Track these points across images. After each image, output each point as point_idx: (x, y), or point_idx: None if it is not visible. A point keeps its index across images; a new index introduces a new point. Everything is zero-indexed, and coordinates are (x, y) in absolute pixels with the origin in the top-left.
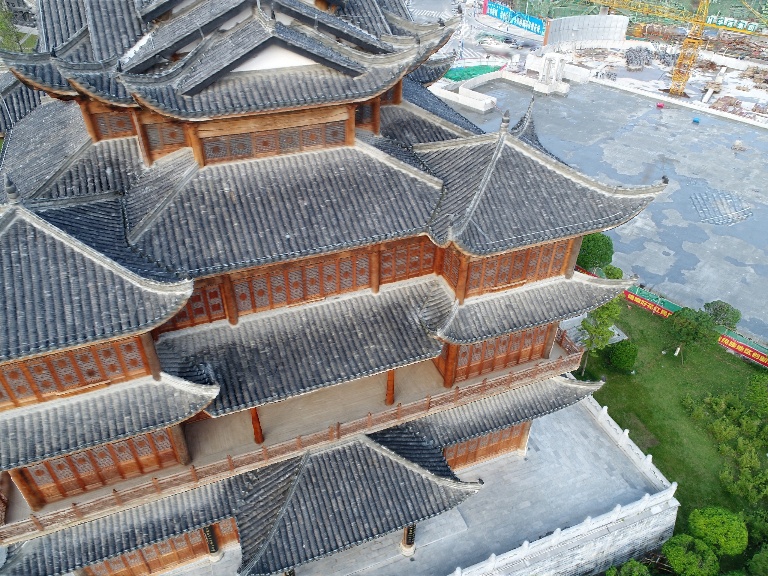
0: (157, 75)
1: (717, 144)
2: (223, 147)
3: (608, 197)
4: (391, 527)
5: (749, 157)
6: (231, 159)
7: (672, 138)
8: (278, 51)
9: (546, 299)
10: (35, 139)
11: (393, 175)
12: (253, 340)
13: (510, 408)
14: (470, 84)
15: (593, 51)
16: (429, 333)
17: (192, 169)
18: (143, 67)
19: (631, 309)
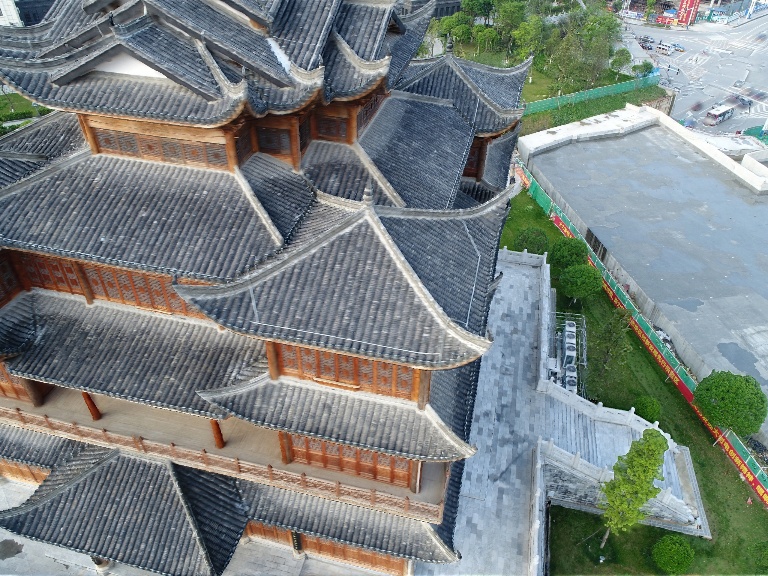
0: (30, 61)
1: None
2: (113, 140)
3: (441, 328)
4: (135, 562)
5: None
6: (122, 153)
7: None
8: None
9: (376, 420)
10: None
11: (246, 215)
12: (91, 324)
13: (352, 523)
14: (766, 154)
15: None
16: None
17: (82, 153)
18: (58, 53)
19: (750, 505)
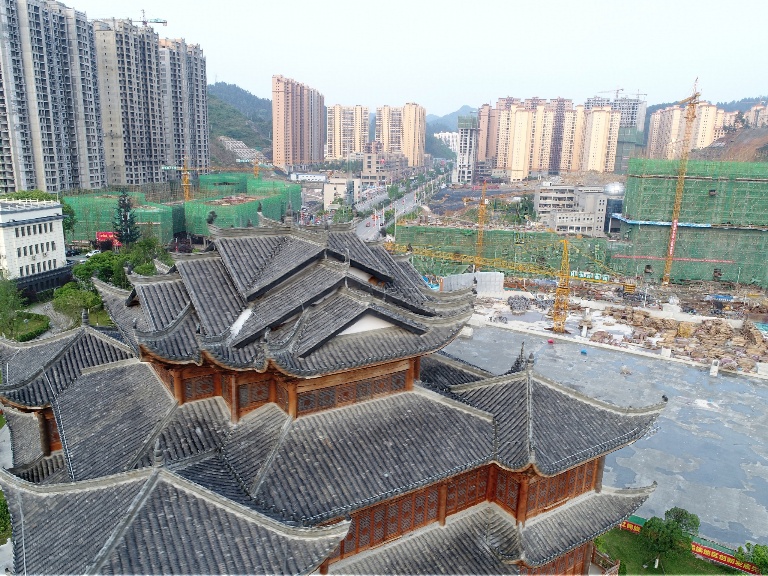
0: (281, 343)
1: (608, 370)
2: (313, 400)
3: (623, 416)
4: None
5: (637, 379)
6: (317, 410)
7: (570, 368)
8: (367, 319)
9: (587, 514)
10: (96, 408)
11: (451, 413)
12: None
13: None
14: None
15: (480, 300)
16: (503, 559)
17: (289, 421)
18: (254, 337)
19: None
